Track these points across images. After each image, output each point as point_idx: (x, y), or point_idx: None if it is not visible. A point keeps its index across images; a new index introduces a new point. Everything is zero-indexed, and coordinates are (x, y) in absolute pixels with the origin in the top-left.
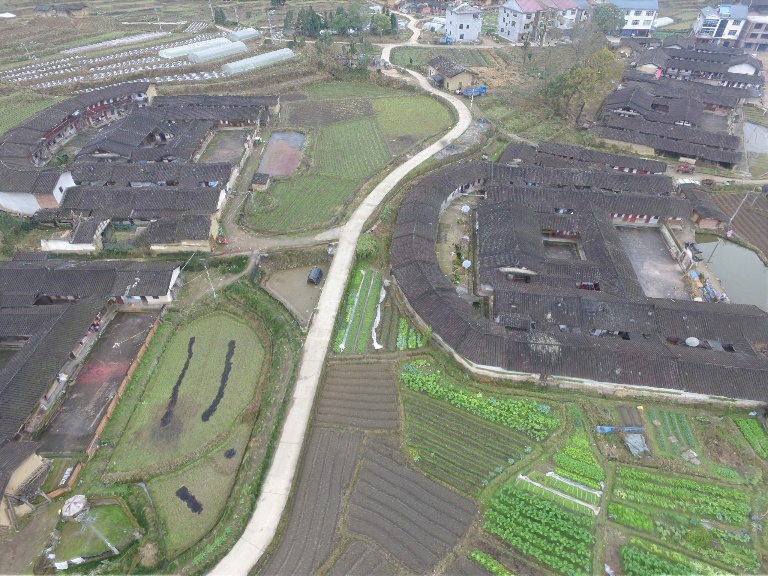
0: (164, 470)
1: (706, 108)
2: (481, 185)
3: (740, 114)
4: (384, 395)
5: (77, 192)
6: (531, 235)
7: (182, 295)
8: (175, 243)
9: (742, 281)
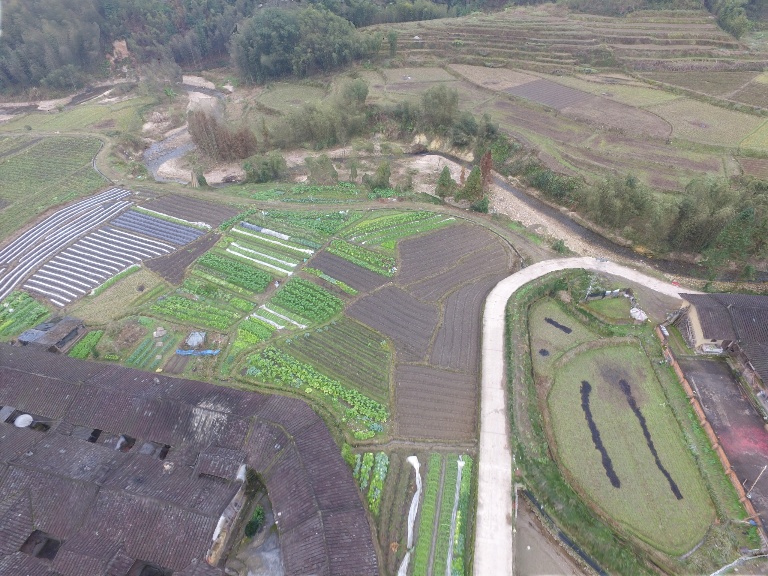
0: None
1: None
2: None
3: None
4: (408, 398)
5: None
6: None
7: None
8: None
9: None
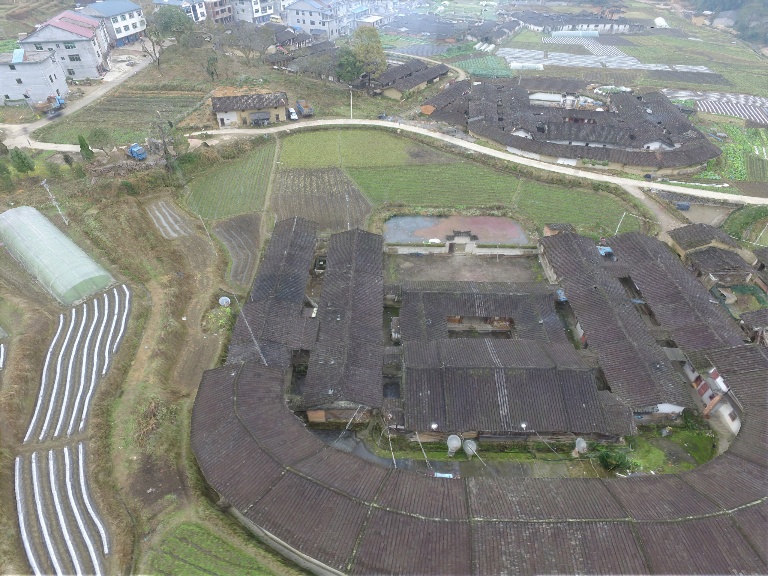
0: None
1: None
2: None
3: None
4: None
5: None
6: None
7: None
8: None
9: None
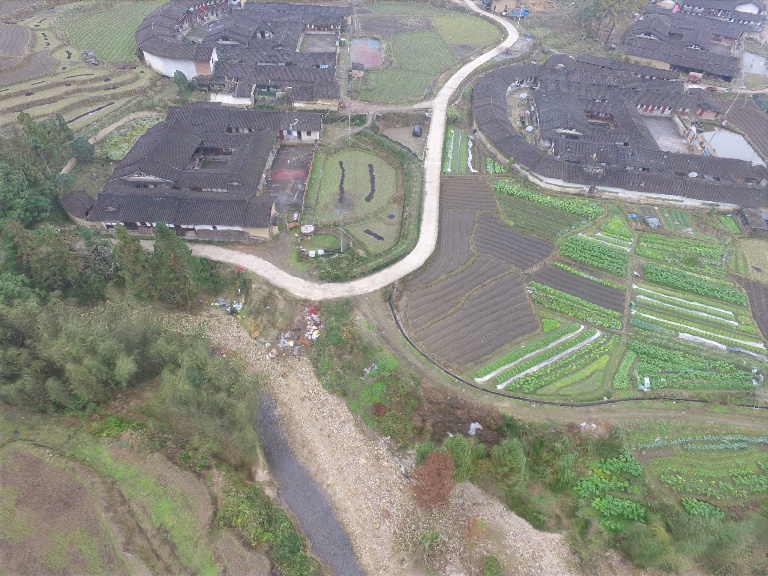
0: (353, 221)
1: (714, 39)
2: (532, 83)
3: (742, 45)
4: (484, 195)
5: (224, 64)
6: (577, 111)
7: (324, 136)
8: (313, 101)
9: (730, 157)
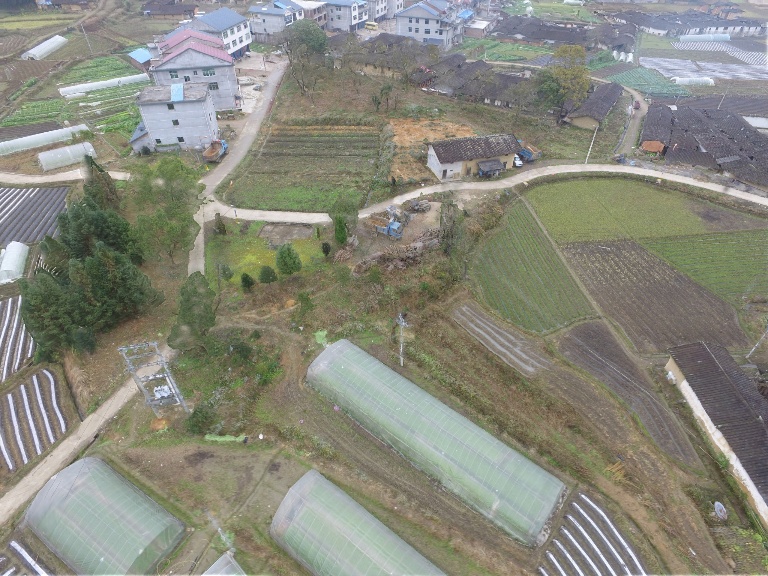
0: None
1: None
2: None
3: None
4: None
5: None
6: None
7: None
8: None
9: None
